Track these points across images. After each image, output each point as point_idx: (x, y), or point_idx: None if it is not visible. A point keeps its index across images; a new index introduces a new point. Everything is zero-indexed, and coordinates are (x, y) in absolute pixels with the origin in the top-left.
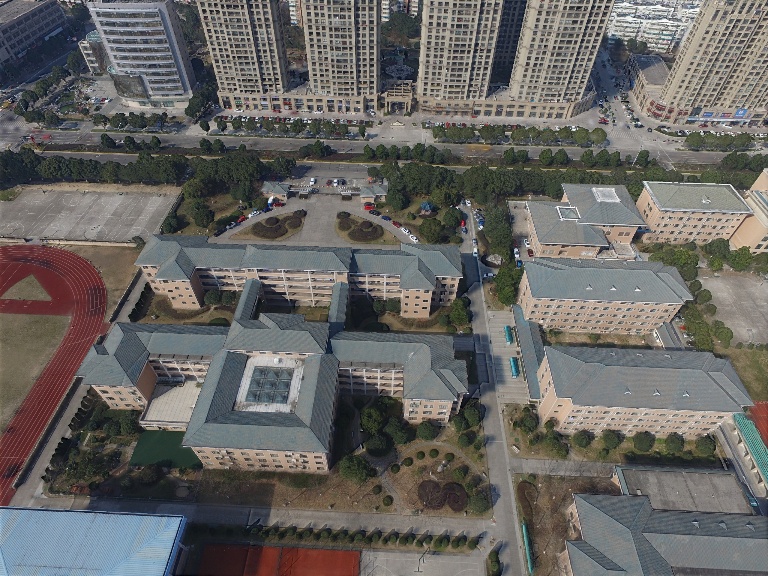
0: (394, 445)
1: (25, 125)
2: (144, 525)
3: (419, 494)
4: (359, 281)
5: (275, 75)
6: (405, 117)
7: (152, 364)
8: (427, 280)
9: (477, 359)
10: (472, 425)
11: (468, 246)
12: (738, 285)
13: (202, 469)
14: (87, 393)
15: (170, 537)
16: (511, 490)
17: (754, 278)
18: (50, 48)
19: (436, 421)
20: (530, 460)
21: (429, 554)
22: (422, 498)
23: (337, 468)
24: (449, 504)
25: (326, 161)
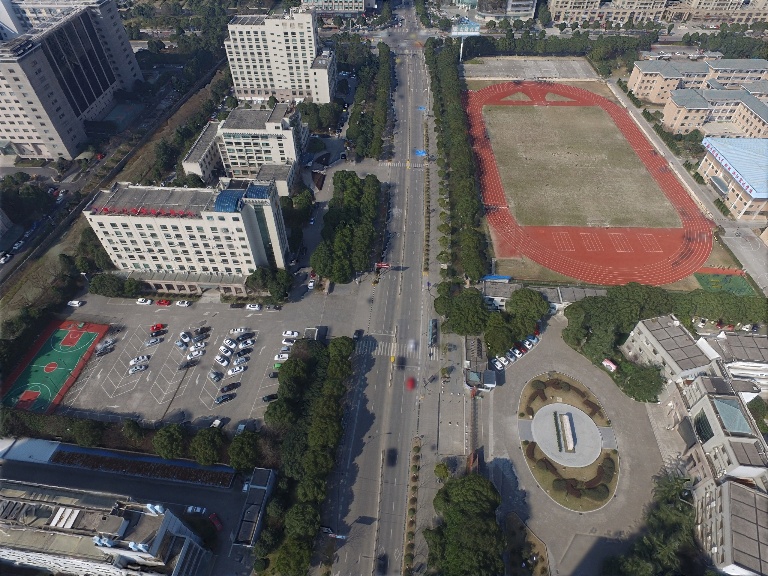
0: None
1: (430, 31)
2: None
3: None
4: None
5: None
6: None
7: None
8: None
9: None
10: None
11: None
12: None
13: None
14: None
15: None
16: None
17: None
18: None
19: None
20: None
21: None
22: None
23: None
24: None
25: (658, 45)
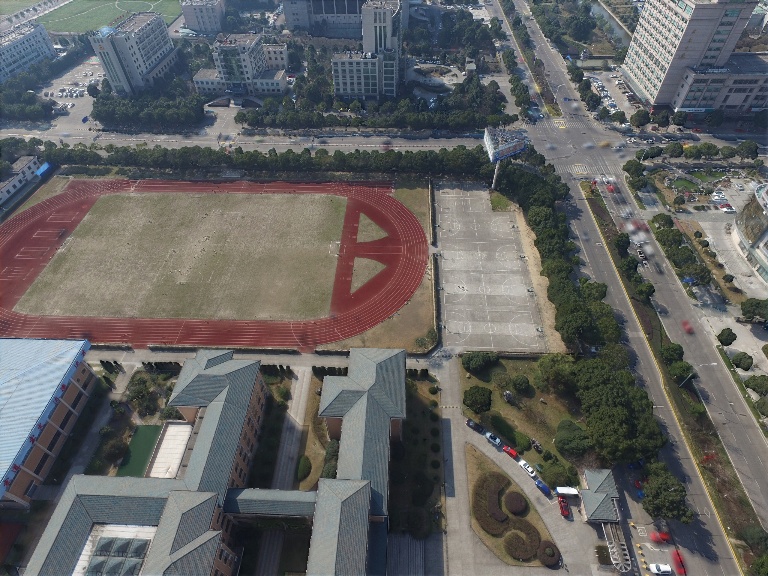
0: None
1: None
2: (3, 464)
3: None
4: None
5: None
6: None
7: None
8: None
9: None
10: None
11: None
12: None
13: None
14: None
15: None
16: None
17: None
18: None
19: None
20: None
21: None
22: None
23: None
24: None
25: None
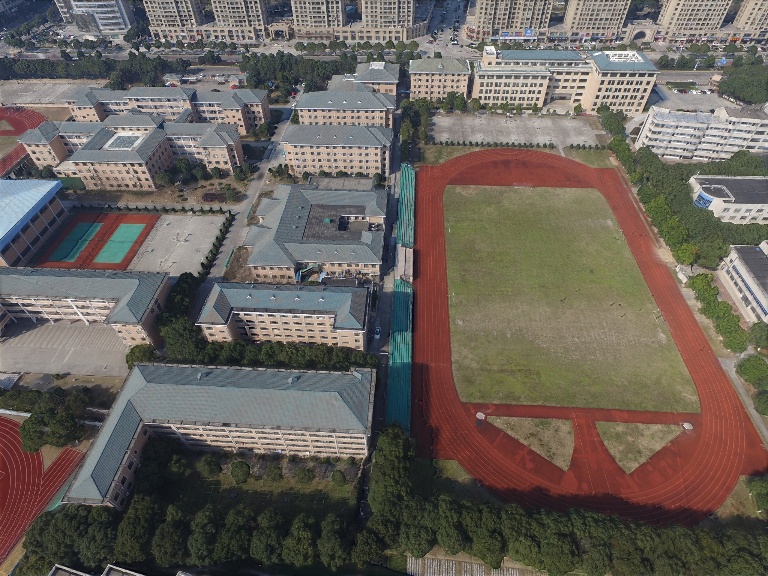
0: (198, 181)
1: (12, 51)
2: (39, 182)
3: (202, 196)
4: (202, 112)
5: (189, 12)
6: (285, 42)
7: (62, 140)
8: (236, 103)
9: (267, 151)
10: (246, 172)
11: (291, 104)
12: (458, 119)
13: (85, 189)
14: (26, 161)
15: (51, 186)
16: (256, 196)
17: (472, 116)
18: (36, 6)
19: (226, 172)
20: (274, 186)
21: (198, 216)
22: (203, 198)
23: (161, 189)
24: (217, 199)
25: (216, 66)
